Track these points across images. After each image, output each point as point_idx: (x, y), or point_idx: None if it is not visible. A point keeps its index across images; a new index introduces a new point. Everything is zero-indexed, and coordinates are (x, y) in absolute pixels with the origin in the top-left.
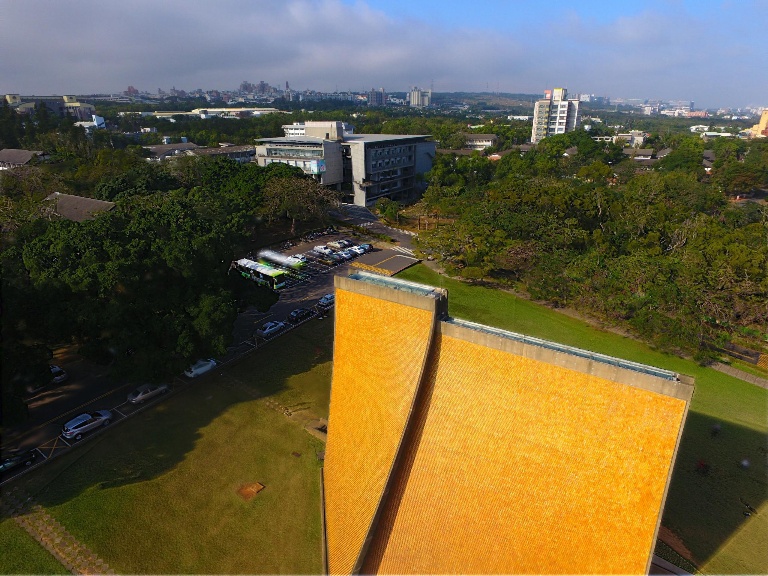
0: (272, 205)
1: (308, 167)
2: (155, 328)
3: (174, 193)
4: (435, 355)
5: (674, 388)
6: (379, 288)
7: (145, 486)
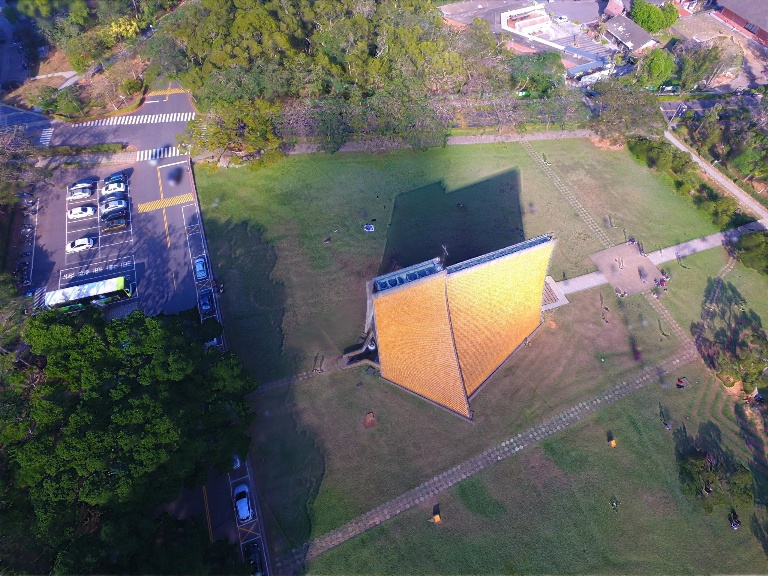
0: None
1: None
2: (219, 421)
3: None
4: None
5: None
6: (409, 284)
7: (328, 478)
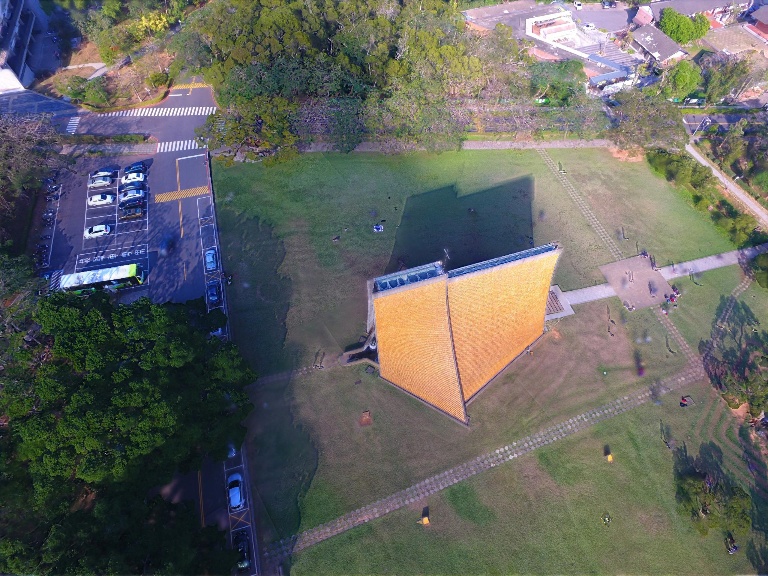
0: None
1: None
2: (216, 410)
3: None
4: None
5: None
6: (409, 286)
7: (320, 473)
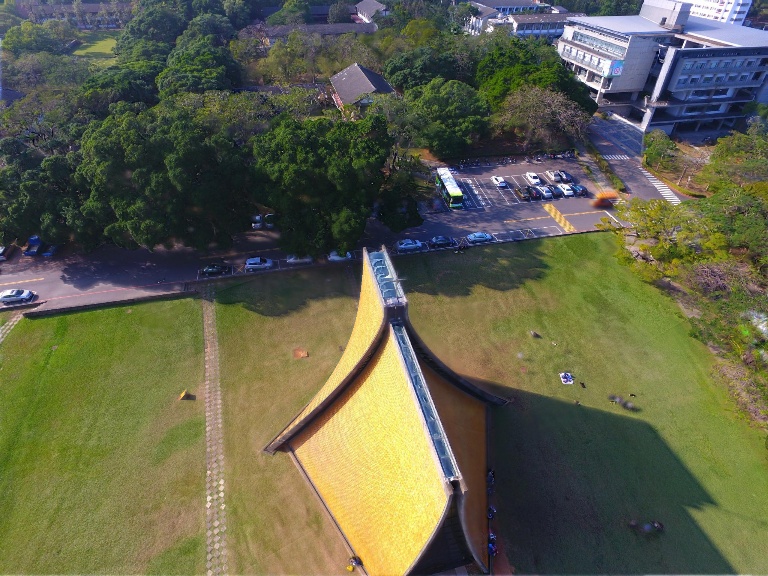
0: (505, 117)
1: (601, 67)
2: (306, 220)
3: (430, 84)
4: (385, 344)
5: (444, 484)
6: (372, 275)
7: (259, 317)
